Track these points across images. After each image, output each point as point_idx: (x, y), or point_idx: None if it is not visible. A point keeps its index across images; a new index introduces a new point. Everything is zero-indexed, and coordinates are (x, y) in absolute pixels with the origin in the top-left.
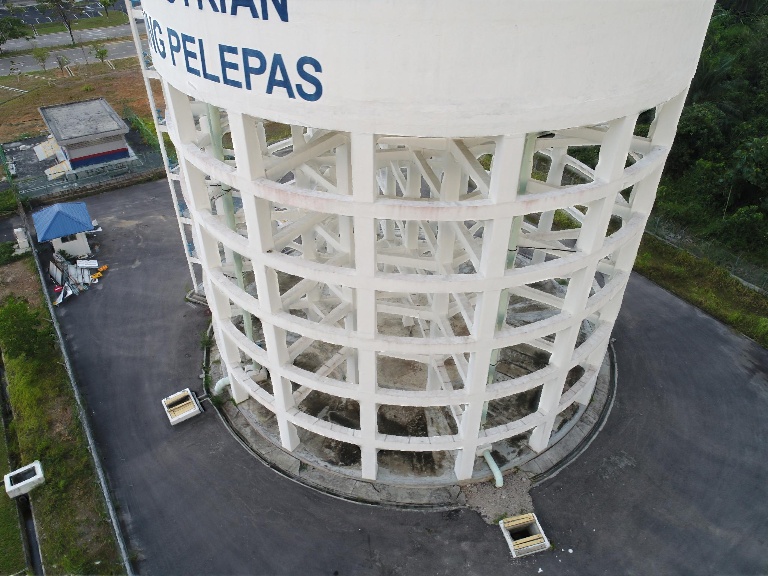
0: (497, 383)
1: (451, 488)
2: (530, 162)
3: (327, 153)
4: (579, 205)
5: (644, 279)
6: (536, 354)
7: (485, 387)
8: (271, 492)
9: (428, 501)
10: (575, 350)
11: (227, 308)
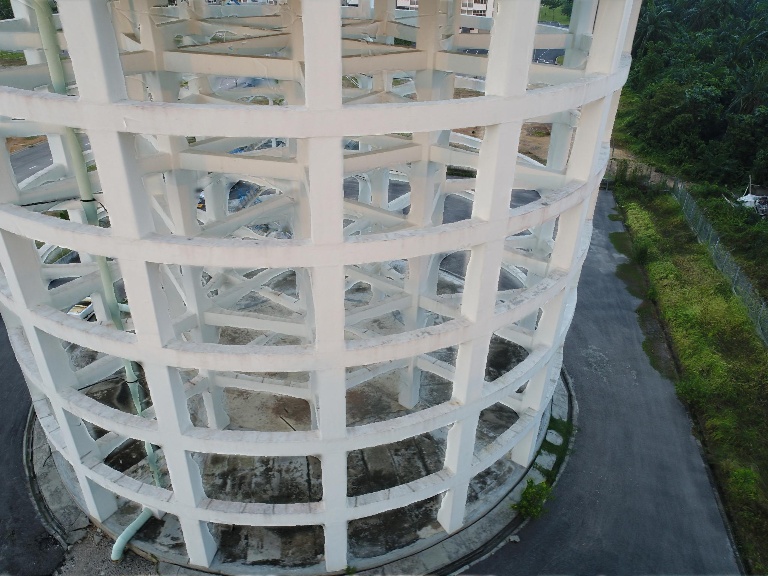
0: (83, 394)
1: (80, 516)
2: (46, 51)
3: (223, 97)
4: (762, 368)
5: (716, 510)
6: (377, 472)
7: (54, 384)
8: (8, 403)
9: (55, 510)
10: None
11: (77, 215)
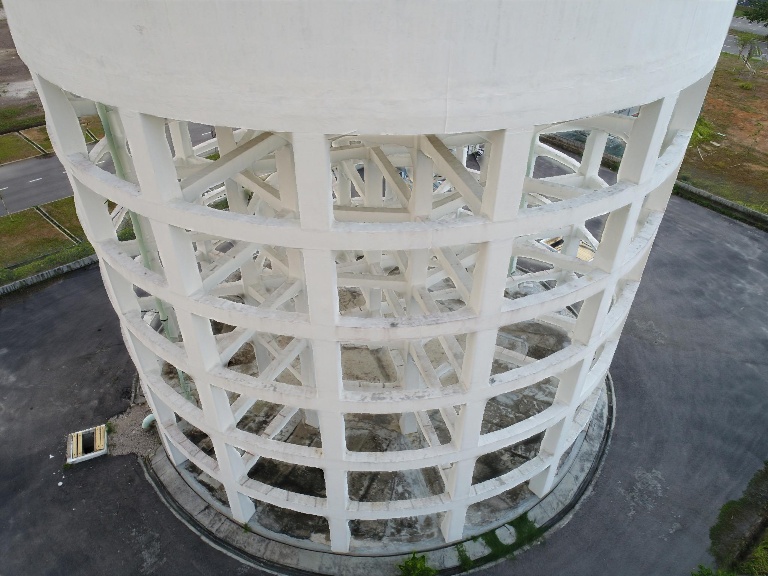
0: None
1: None
2: None
3: None
4: None
5: None
6: None
7: None
8: None
9: None
10: (162, 380)
11: None
